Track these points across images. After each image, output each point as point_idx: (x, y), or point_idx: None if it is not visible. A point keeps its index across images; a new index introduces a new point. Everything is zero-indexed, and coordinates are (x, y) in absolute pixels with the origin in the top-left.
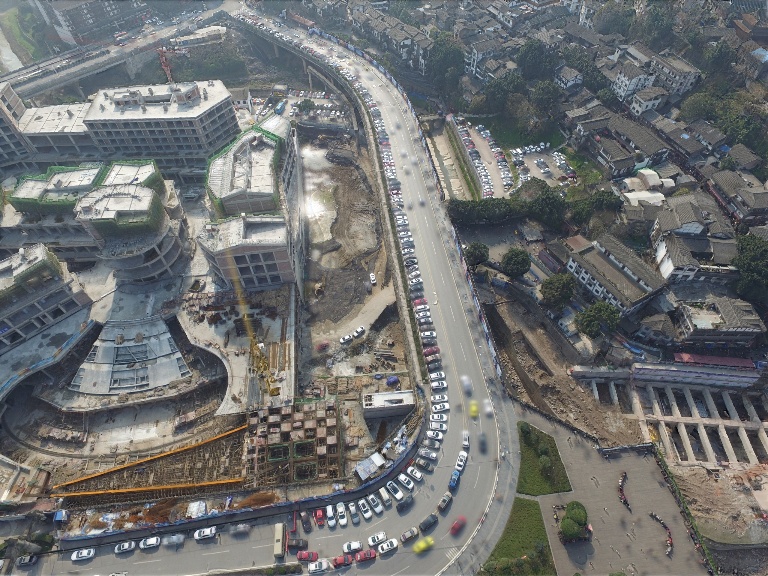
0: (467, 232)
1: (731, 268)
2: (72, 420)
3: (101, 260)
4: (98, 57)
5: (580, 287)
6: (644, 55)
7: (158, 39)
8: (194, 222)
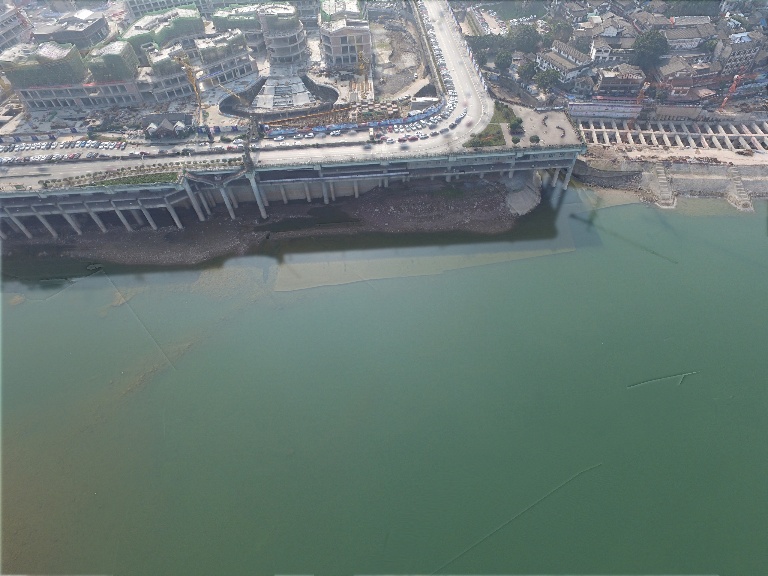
0: None
1: (630, 49)
2: None
3: (259, 56)
4: None
5: None
6: None
7: None
8: (309, 42)
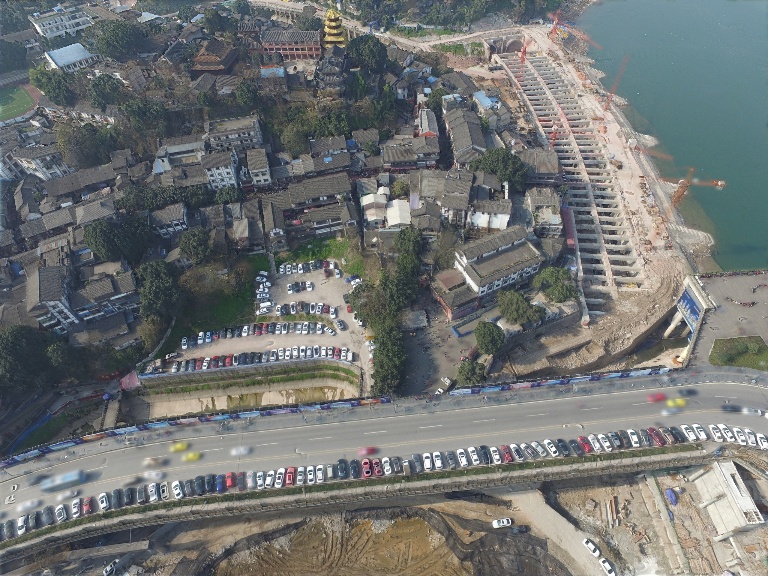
0: (407, 388)
1: (507, 184)
2: None
3: None
4: None
5: None
6: (189, 143)
7: None
8: None
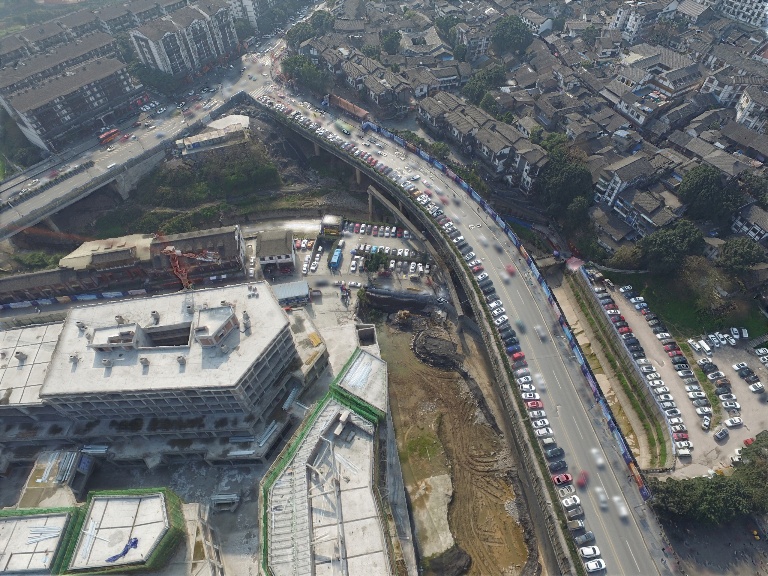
0: (673, 531)
1: None
2: None
3: None
4: (77, 173)
5: None
6: None
7: (159, 142)
8: (235, 570)
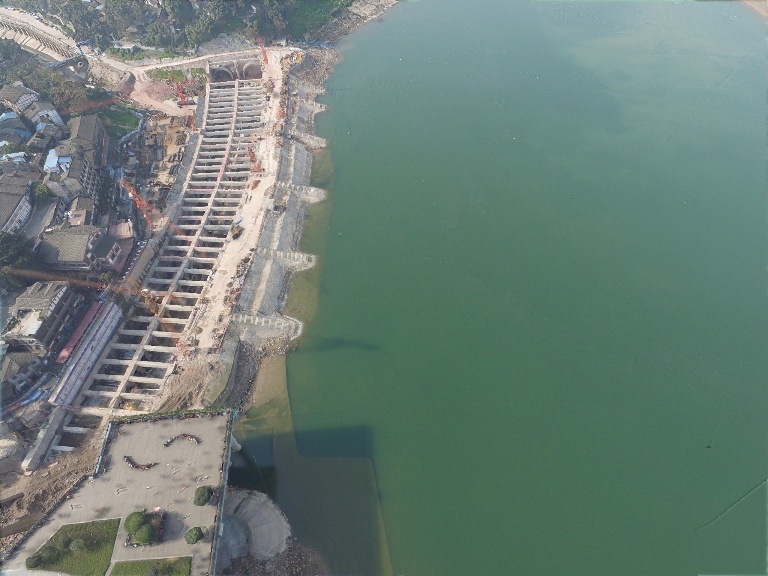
0: None
1: None
2: None
3: None
4: None
5: None
6: None
7: None
8: None
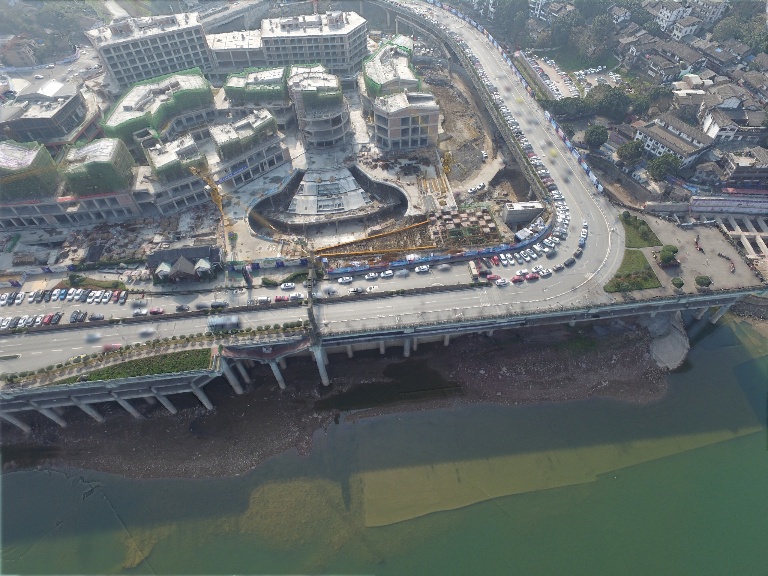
0: None
1: (762, 127)
2: (294, 231)
3: (287, 136)
4: (221, 12)
5: (645, 154)
6: None
7: None
8: None
